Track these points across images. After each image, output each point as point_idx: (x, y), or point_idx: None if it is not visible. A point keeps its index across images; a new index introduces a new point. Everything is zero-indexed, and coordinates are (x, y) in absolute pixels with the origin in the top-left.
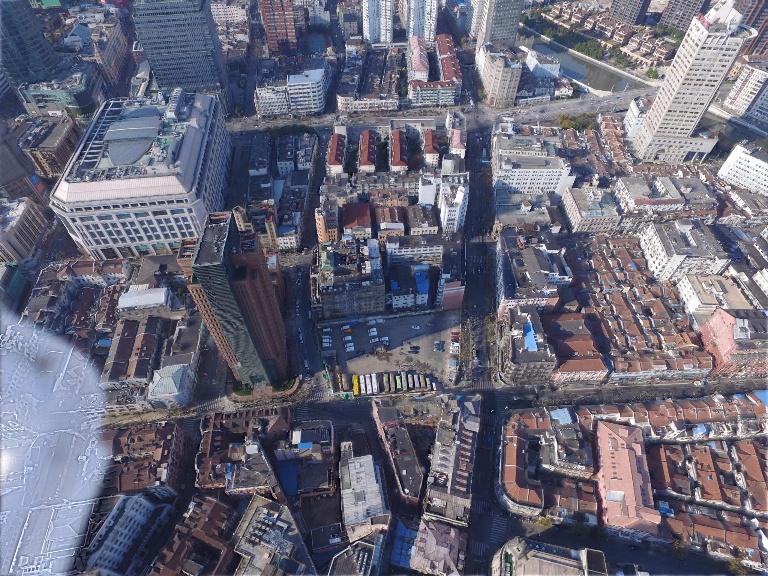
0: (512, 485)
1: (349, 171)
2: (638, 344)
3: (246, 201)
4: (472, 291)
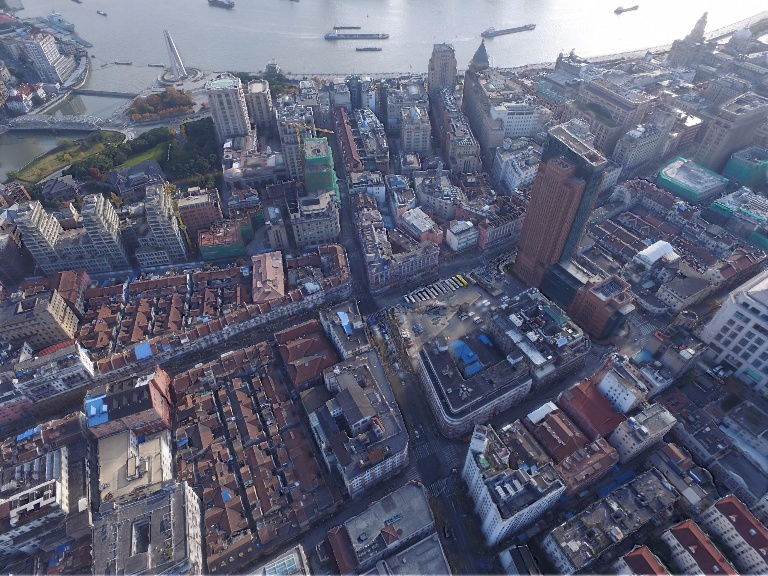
0: (338, 247)
1: (704, 525)
2: (240, 382)
3: (746, 398)
4: (413, 400)
